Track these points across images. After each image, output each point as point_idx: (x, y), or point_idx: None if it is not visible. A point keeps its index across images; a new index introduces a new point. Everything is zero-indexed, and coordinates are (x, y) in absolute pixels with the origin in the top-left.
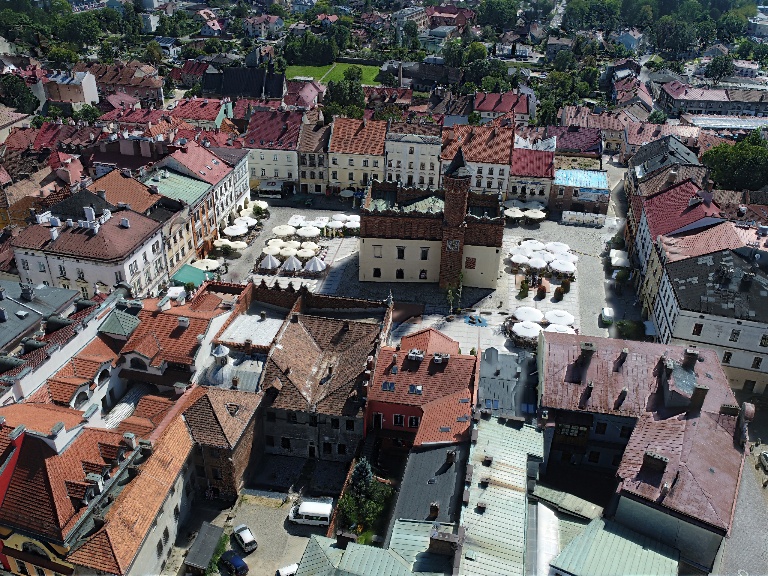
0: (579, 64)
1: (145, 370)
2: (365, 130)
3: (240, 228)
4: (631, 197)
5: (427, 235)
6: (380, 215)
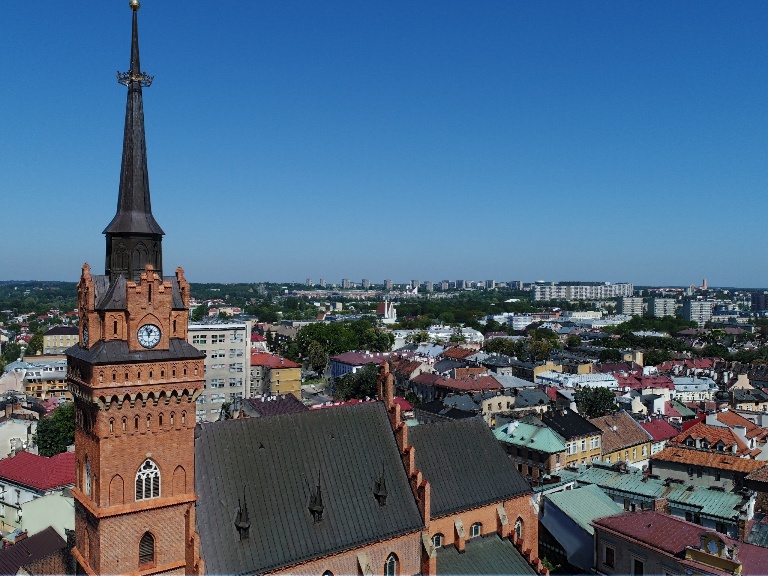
0: None
1: None
2: None
3: None
4: None
5: None
6: None
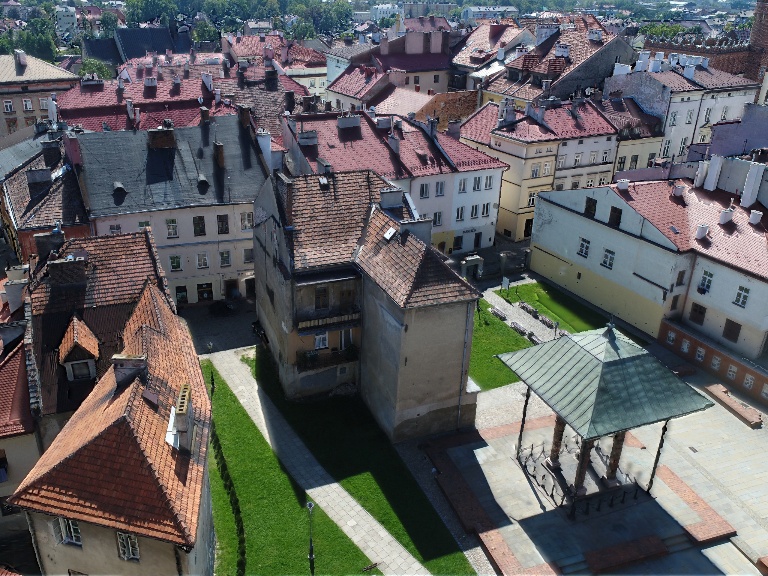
0: (317, 36)
1: None
2: None
3: None
4: None
5: (739, 69)
6: (725, 52)
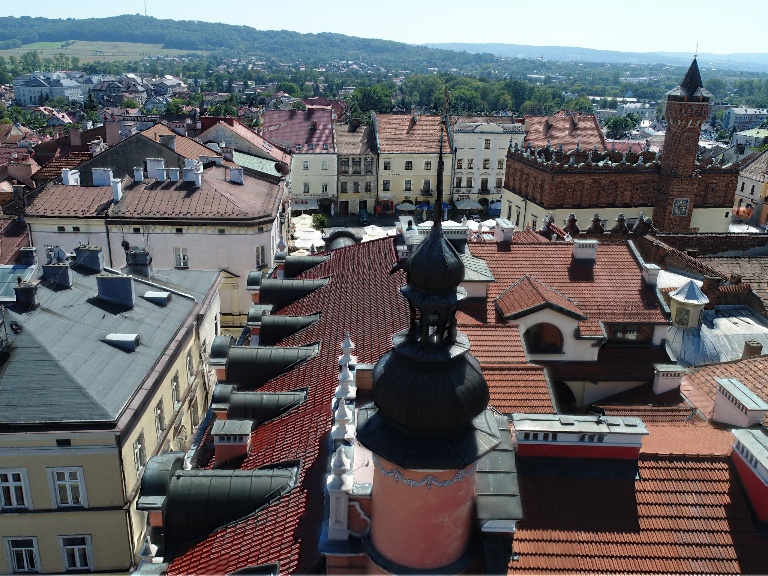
0: None
1: (558, 353)
2: (418, 126)
3: (314, 238)
4: (767, 173)
5: (635, 200)
6: (578, 172)
